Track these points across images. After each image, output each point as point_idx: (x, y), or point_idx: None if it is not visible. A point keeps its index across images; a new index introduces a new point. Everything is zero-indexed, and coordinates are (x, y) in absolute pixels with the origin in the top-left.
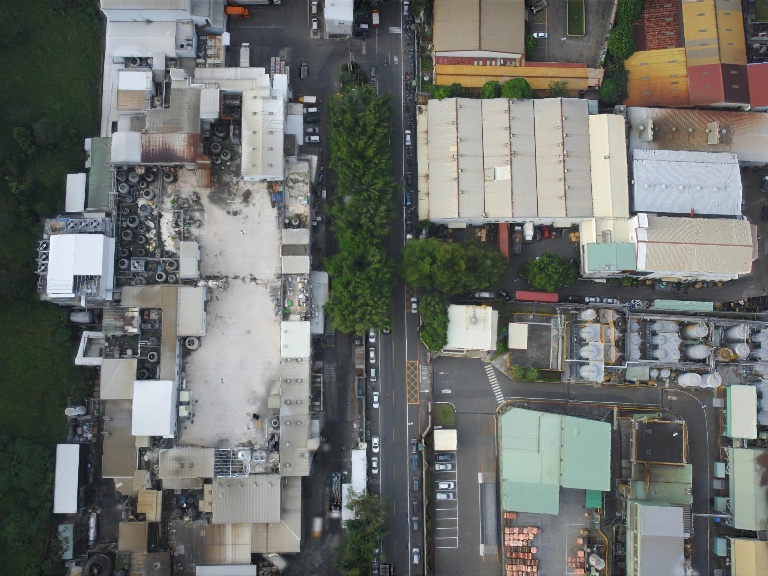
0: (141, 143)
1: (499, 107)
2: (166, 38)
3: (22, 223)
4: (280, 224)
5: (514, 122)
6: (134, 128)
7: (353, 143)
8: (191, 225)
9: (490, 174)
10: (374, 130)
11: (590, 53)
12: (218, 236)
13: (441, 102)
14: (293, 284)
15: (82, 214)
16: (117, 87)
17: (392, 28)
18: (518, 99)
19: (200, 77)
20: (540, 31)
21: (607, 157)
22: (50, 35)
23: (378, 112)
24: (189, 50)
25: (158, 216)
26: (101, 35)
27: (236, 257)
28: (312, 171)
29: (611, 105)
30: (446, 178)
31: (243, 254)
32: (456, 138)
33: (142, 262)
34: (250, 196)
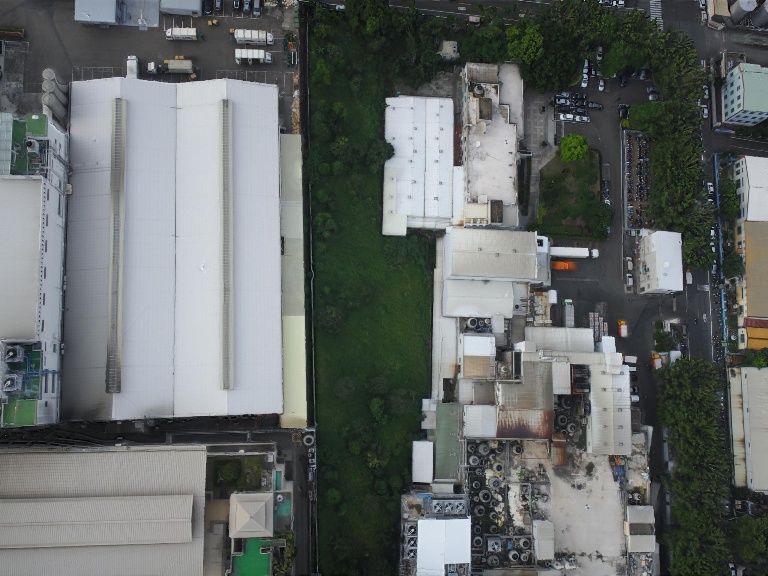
0: (496, 417)
1: None
2: (505, 300)
3: (377, 498)
4: (623, 499)
5: None
6: (478, 395)
7: (696, 421)
8: (538, 499)
9: None
10: (711, 406)
11: None
12: (564, 511)
13: (760, 371)
14: (636, 561)
15: (429, 484)
16: (463, 353)
17: (700, 286)
18: None
19: (532, 337)
20: None
21: None
22: (390, 292)
23: None
24: (524, 311)
25: (507, 489)
26: (430, 287)
27: (582, 533)
28: (648, 442)
29: None
30: None
31: (589, 530)
32: None
33: (500, 543)
34: (593, 469)
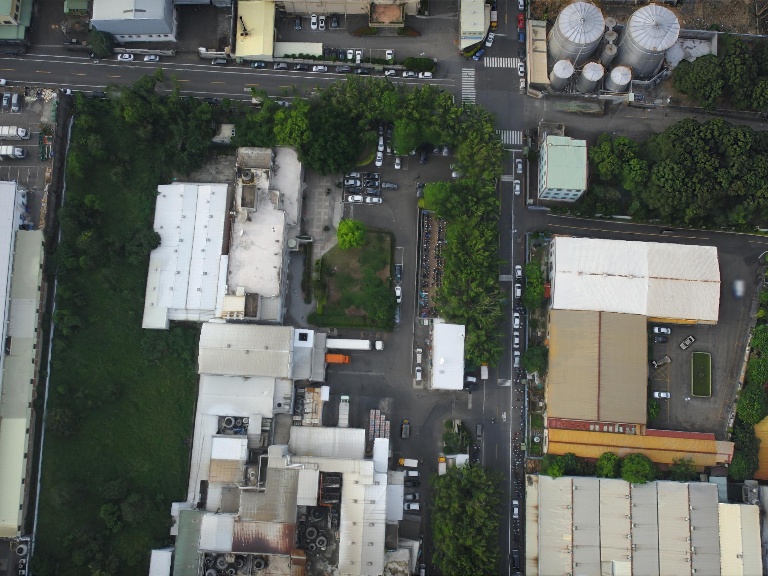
0: (233, 529)
1: (619, 490)
2: (264, 399)
3: None
4: None
5: (636, 509)
6: (225, 501)
7: (461, 540)
8: None
9: (608, 570)
10: (483, 522)
11: (717, 416)
12: None
13: (555, 481)
14: None
15: None
16: (210, 456)
17: (501, 380)
18: (641, 483)
19: (296, 438)
20: (662, 389)
21: (740, 557)
22: (143, 388)
23: (488, 501)
24: (287, 410)
25: None
26: (195, 381)
27: None
28: (413, 560)
29: (741, 480)
30: (559, 572)
31: None
32: (571, 525)
33: None
34: None
